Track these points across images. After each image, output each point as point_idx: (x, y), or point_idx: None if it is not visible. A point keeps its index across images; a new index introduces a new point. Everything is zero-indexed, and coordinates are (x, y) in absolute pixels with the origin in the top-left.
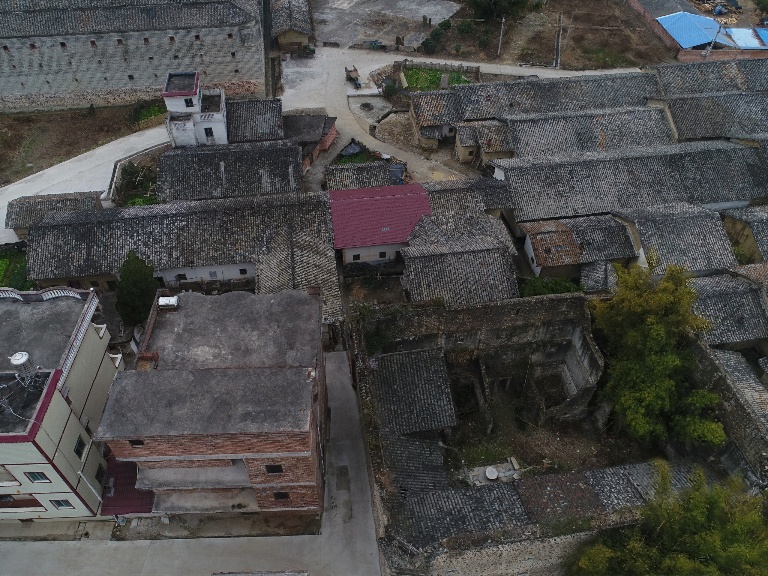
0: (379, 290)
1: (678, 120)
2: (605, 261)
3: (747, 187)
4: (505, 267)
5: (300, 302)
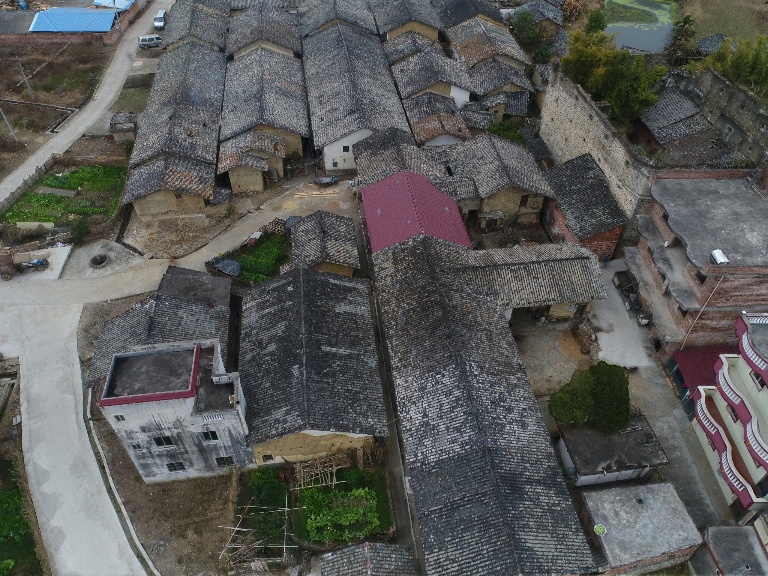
0: (483, 249)
1: (283, 44)
2: (464, 110)
3: (373, 43)
4: (503, 141)
5: (666, 189)
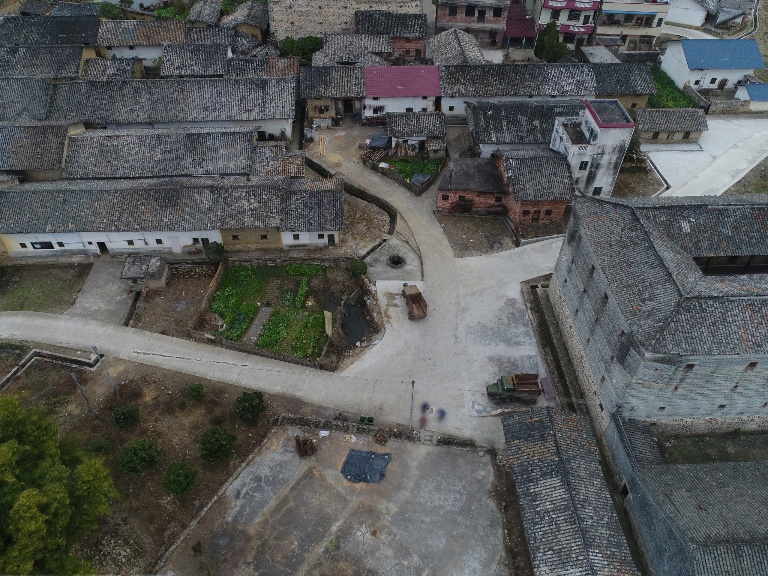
0: None
1: None
2: None
3: None
4: None
5: None
